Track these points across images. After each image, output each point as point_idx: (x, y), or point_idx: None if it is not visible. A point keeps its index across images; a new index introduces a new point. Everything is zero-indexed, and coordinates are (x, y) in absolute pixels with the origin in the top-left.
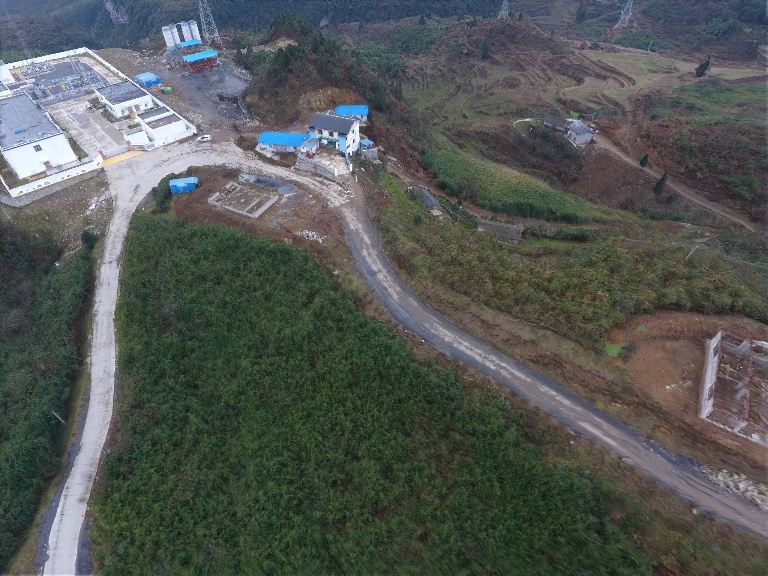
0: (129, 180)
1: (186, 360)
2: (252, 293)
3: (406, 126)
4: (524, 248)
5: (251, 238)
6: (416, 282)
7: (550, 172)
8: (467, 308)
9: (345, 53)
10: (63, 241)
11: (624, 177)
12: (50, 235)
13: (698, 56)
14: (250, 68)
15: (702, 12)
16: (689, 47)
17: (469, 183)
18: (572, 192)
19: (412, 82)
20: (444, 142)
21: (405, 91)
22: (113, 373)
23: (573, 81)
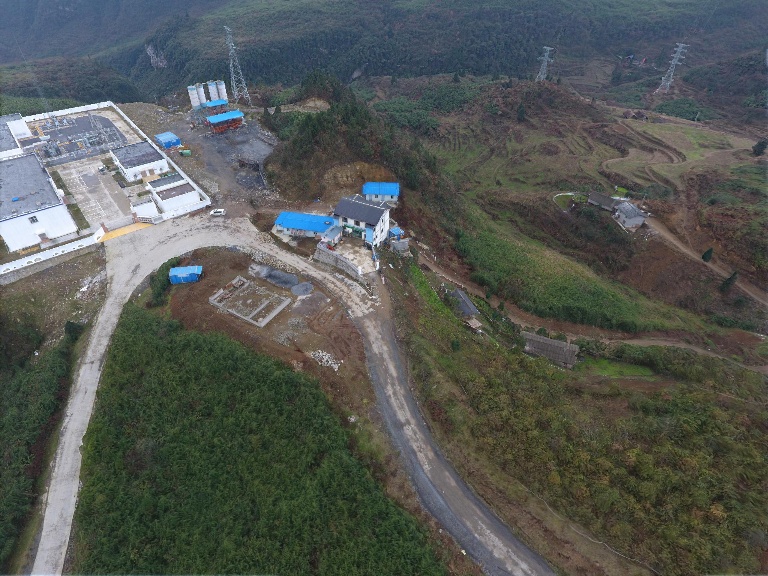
0: (129, 258)
1: (156, 524)
2: (247, 435)
3: (440, 204)
4: (581, 378)
5: (253, 357)
6: (454, 447)
7: (595, 256)
8: (524, 504)
9: (377, 122)
10: (47, 327)
11: (683, 271)
12: (33, 319)
13: (749, 129)
14: (276, 130)
15: (750, 83)
16: (738, 119)
17: (510, 277)
18: (621, 282)
19: (443, 141)
20: (479, 218)
21: (436, 150)
22: (71, 519)
23: (616, 152)
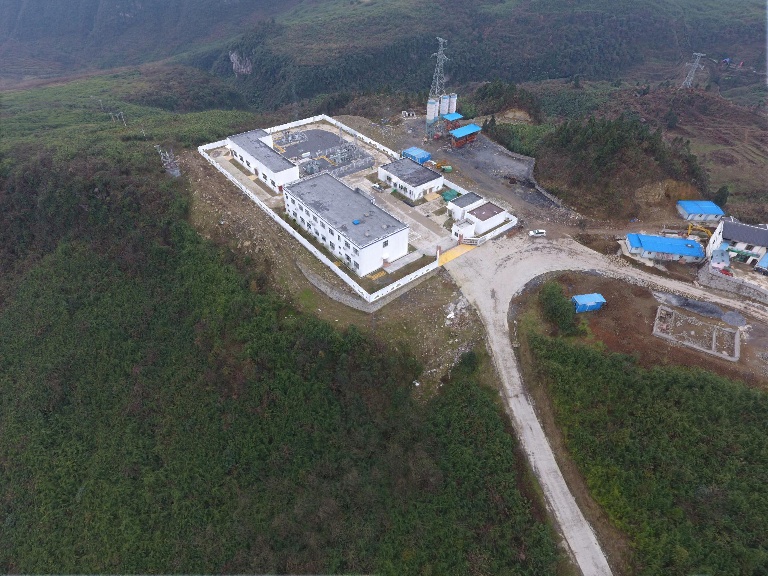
0: (479, 283)
1: None
2: None
3: None
4: None
5: (763, 395)
6: None
7: None
8: None
9: None
10: (423, 356)
11: None
12: (409, 348)
13: None
14: (505, 143)
15: None
16: None
17: None
18: None
19: None
20: None
21: None
22: (609, 569)
23: None
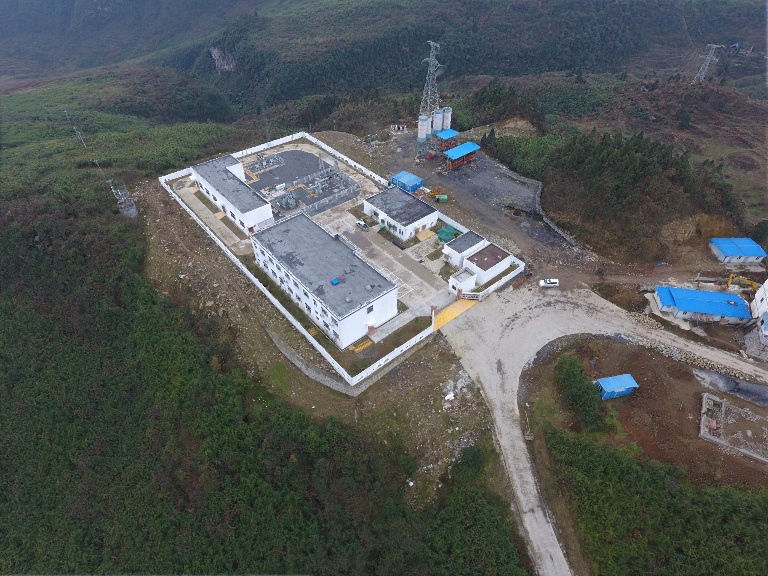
0: (482, 351)
1: None
2: None
3: None
4: None
5: None
6: None
7: None
8: None
9: None
10: (417, 448)
11: None
12: (400, 440)
13: None
14: (506, 161)
15: None
16: None
17: None
18: None
19: None
20: None
21: None
22: None
23: None
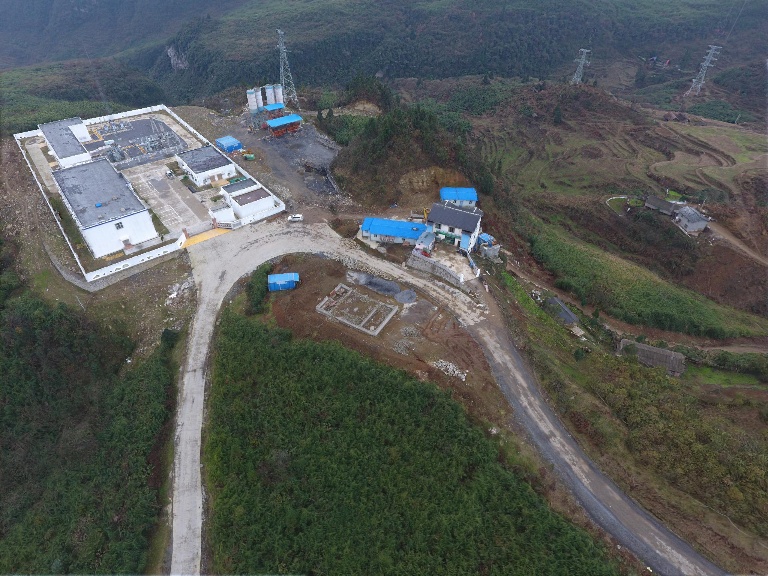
0: (214, 264)
1: (302, 537)
2: (383, 446)
3: (509, 209)
4: (695, 387)
5: (375, 366)
6: (609, 460)
7: (656, 260)
8: (703, 520)
9: (443, 127)
10: (138, 334)
11: (753, 276)
12: (124, 326)
13: None
14: (332, 134)
15: None
16: None
17: (591, 283)
18: (687, 287)
19: None
20: (540, 223)
21: None
22: (199, 531)
23: (661, 155)
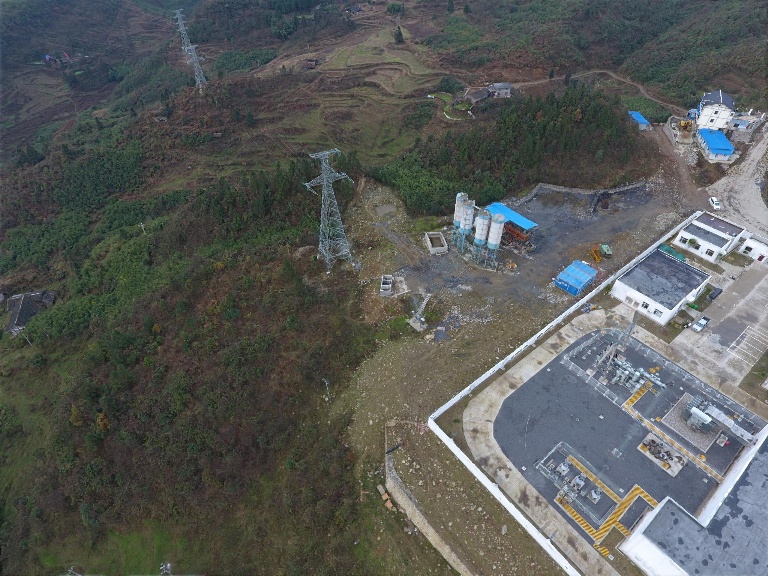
0: None
1: None
2: None
3: None
4: None
5: None
6: None
7: None
8: None
9: None
10: None
11: None
12: None
13: (322, 43)
14: None
15: (248, 20)
16: (303, 41)
17: None
18: None
19: None
20: None
21: None
22: None
23: (365, 87)
